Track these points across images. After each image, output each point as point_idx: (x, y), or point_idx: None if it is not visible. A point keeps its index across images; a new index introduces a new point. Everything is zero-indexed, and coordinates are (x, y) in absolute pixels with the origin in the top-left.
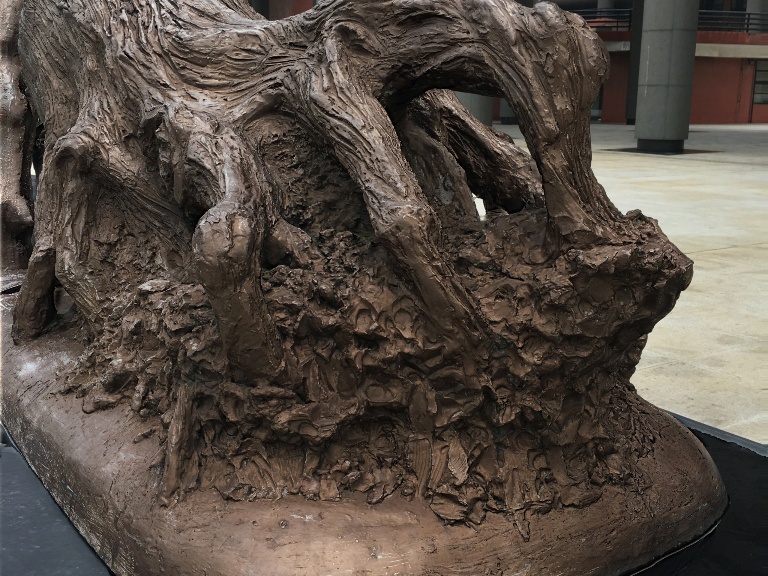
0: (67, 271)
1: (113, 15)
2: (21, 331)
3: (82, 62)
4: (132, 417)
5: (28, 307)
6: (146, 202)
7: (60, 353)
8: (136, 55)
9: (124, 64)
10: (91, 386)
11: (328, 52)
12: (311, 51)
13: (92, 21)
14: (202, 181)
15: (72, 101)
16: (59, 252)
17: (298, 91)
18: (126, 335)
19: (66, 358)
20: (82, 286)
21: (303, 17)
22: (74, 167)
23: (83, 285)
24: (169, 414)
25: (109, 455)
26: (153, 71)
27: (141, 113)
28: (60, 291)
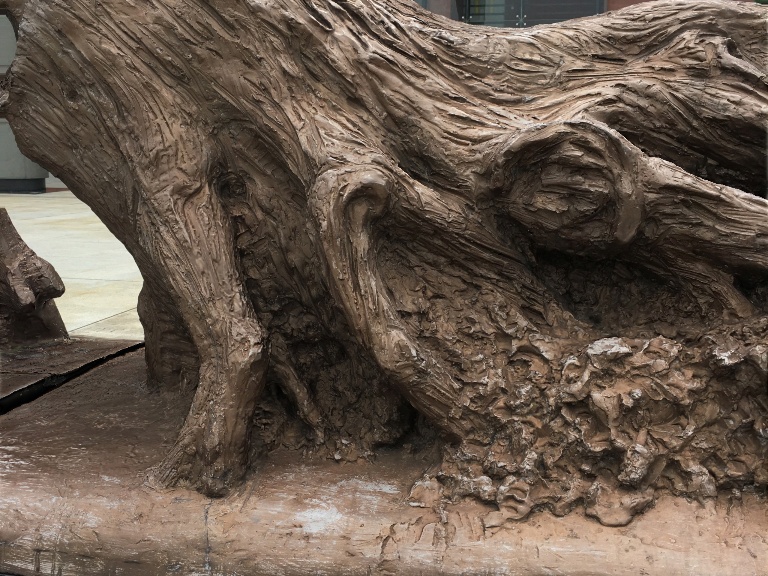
0: (416, 357)
1: (313, 1)
2: (227, 473)
3: (261, 64)
4: (715, 505)
5: (238, 433)
6: (481, 249)
7: (346, 483)
8: (397, 58)
9: (380, 69)
10: (595, 492)
11: (744, 67)
12: (656, 65)
13: (281, 6)
14: (684, 210)
15: (199, 121)
16: (382, 333)
17: (664, 108)
18: (617, 414)
19: (376, 485)
20: (434, 374)
21: (605, 27)
22: (367, 211)
23: (433, 372)
24: None
25: (764, 553)
26: (433, 80)
27: (427, 135)
28: (15, 421)
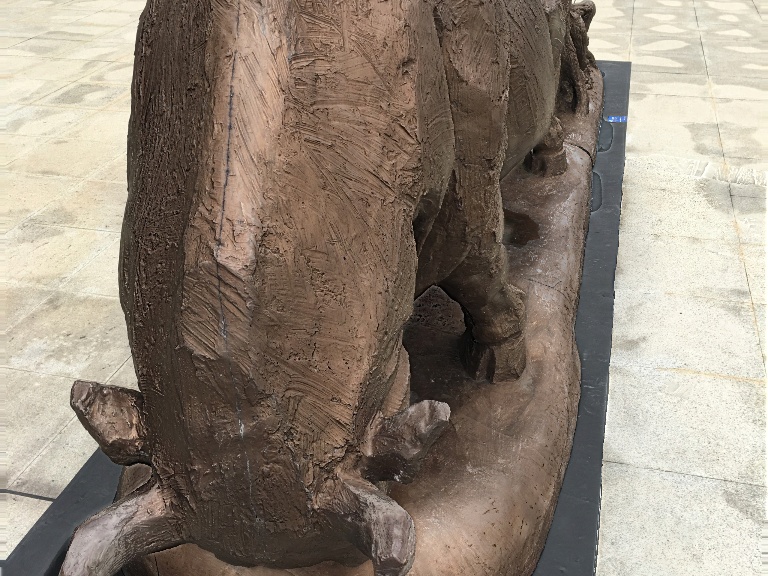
0: None
1: None
2: None
3: None
4: None
5: None
6: None
7: None
8: None
9: None
10: None
11: None
12: None
13: None
14: None
15: None
16: None
17: None
18: None
19: None
20: None
21: None
22: None
23: None
24: (588, 60)
25: None
26: None
27: None
28: None
